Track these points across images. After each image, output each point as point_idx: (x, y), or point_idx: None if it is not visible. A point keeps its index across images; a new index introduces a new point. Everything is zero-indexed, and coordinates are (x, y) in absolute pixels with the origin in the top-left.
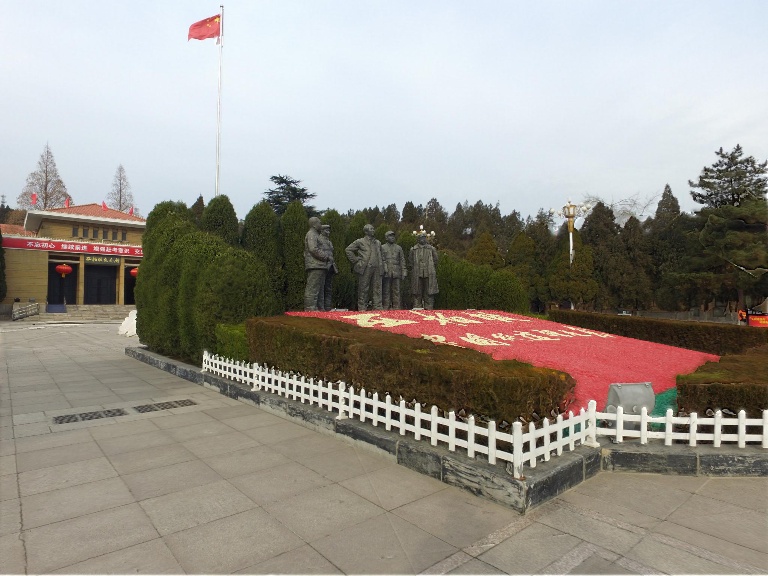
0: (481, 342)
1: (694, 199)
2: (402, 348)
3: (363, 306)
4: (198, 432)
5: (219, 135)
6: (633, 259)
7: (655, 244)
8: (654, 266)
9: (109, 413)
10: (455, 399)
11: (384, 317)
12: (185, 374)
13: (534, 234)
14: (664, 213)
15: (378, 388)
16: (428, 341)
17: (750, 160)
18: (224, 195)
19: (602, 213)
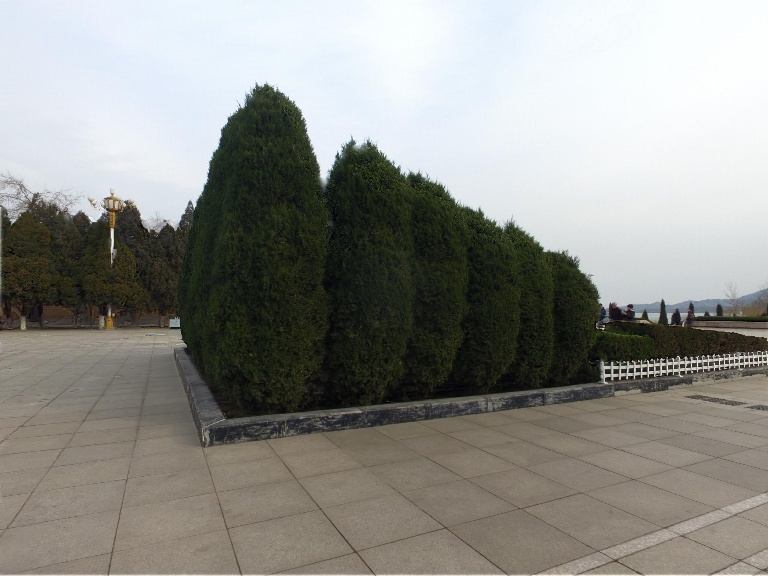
0: None
1: None
2: None
3: None
4: None
5: None
6: (174, 266)
7: None
8: None
9: (765, 408)
10: (760, 348)
11: None
12: (573, 396)
13: (44, 219)
14: None
15: (740, 351)
16: None
17: None
18: None
19: (133, 213)
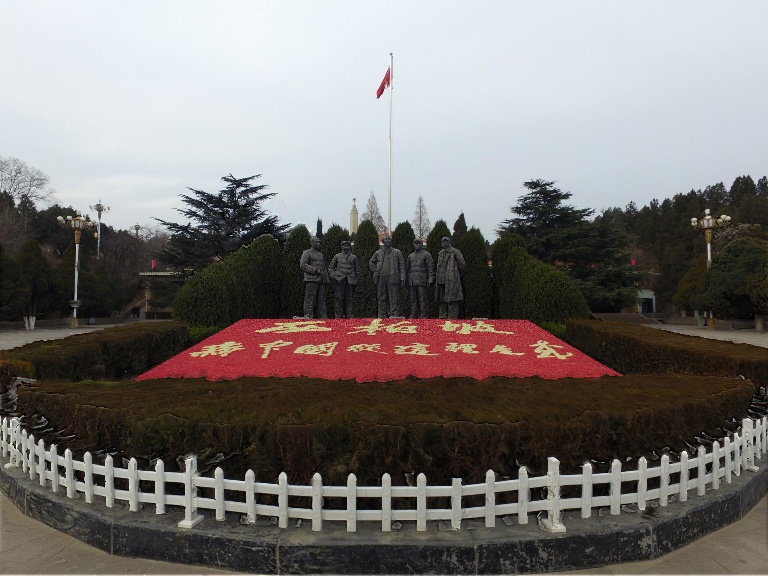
0: (308, 350)
1: None
2: (41, 343)
3: (380, 314)
4: None
5: (391, 165)
6: None
7: None
8: None
9: None
10: None
11: (317, 324)
12: None
13: None
14: None
15: None
16: (114, 341)
17: None
18: (302, 225)
19: None
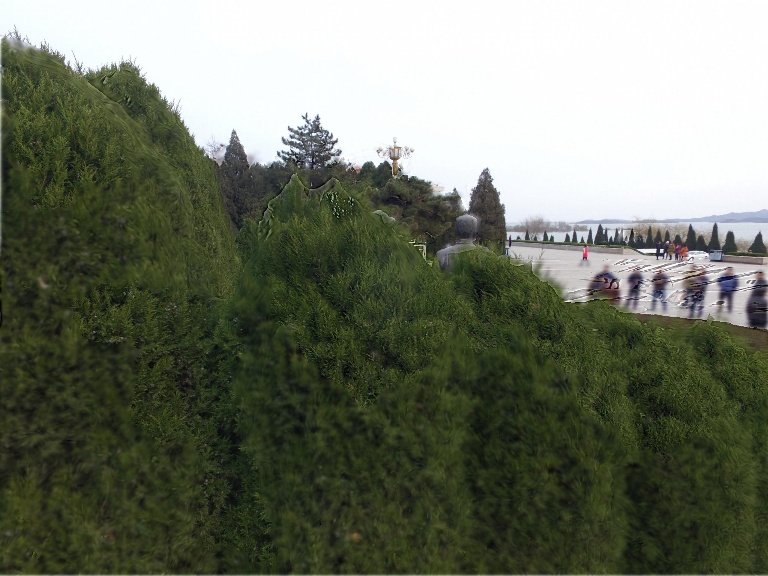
0: None
1: (278, 154)
2: None
3: None
4: None
5: None
6: None
7: (236, 192)
8: (237, 214)
9: None
10: None
11: None
12: None
13: None
14: (234, 159)
15: None
16: None
17: (327, 131)
18: None
19: None
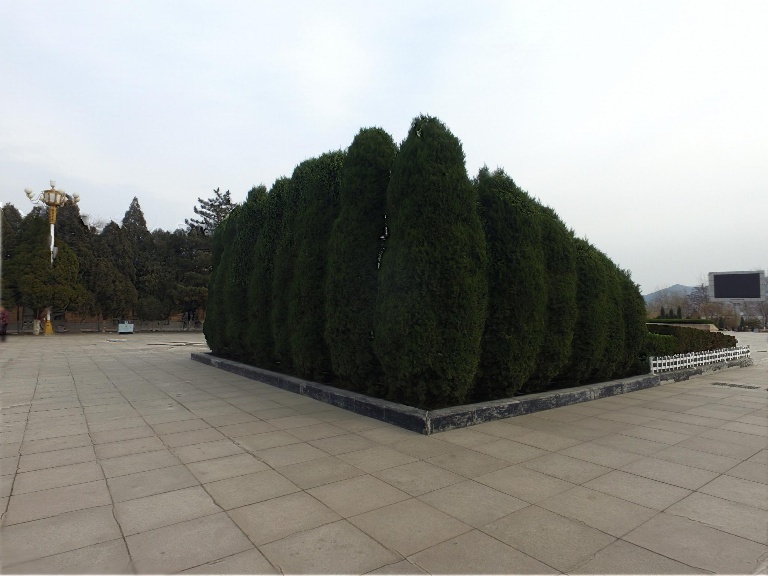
0: None
1: (186, 222)
2: None
3: None
4: (764, 379)
5: None
6: (120, 267)
7: (137, 254)
8: (135, 276)
9: None
10: None
11: None
12: (638, 385)
13: None
14: None
15: None
16: None
17: None
18: None
19: (72, 208)
